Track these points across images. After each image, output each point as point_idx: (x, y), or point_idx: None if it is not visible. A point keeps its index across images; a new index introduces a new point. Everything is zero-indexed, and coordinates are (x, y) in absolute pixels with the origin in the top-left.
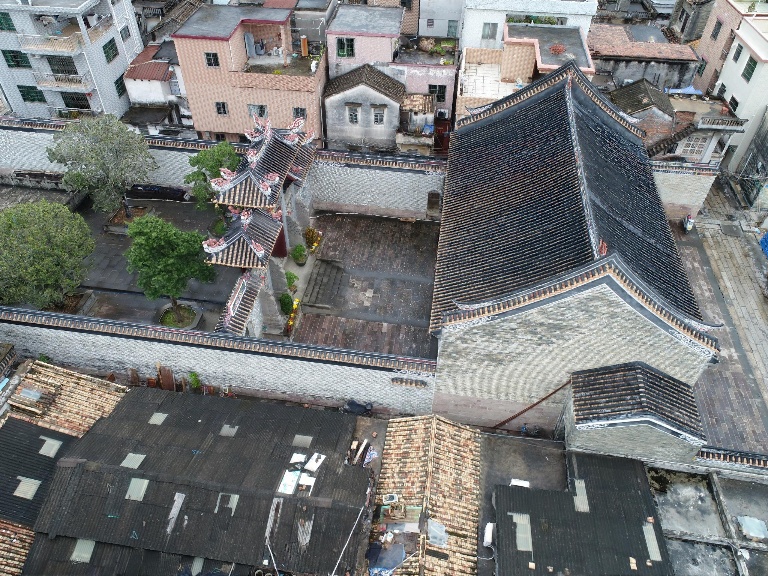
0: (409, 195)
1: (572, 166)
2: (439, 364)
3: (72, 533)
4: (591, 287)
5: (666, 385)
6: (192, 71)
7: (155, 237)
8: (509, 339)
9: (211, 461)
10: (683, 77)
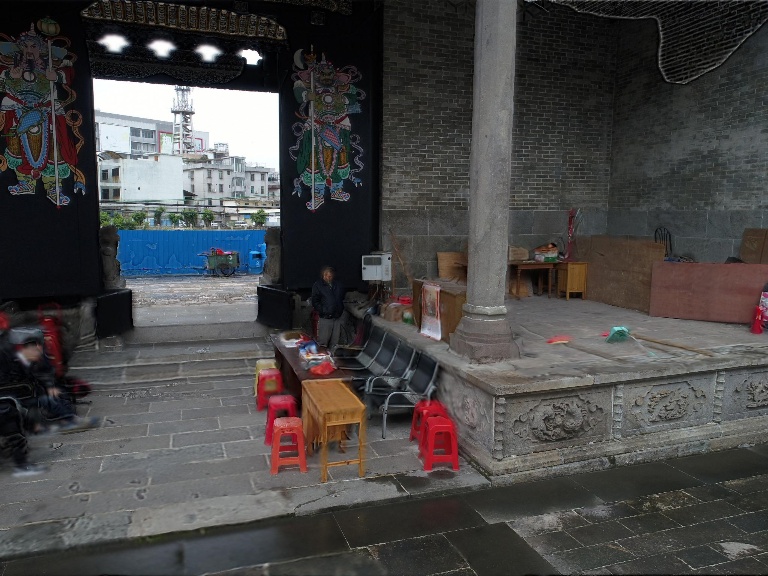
0: None
1: None
2: None
3: None
4: None
5: None
6: None
7: None
8: None
9: None
10: None
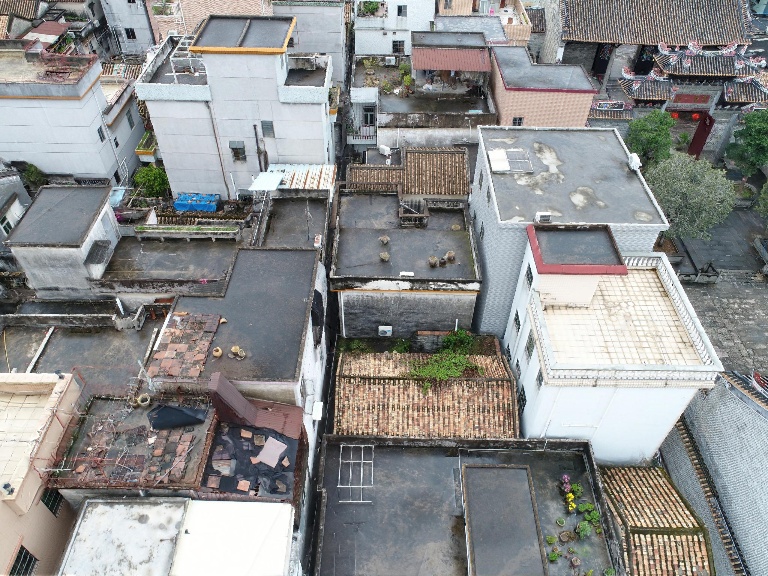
0: None
1: None
2: None
3: None
4: None
5: None
6: None
7: None
8: None
9: None
10: None
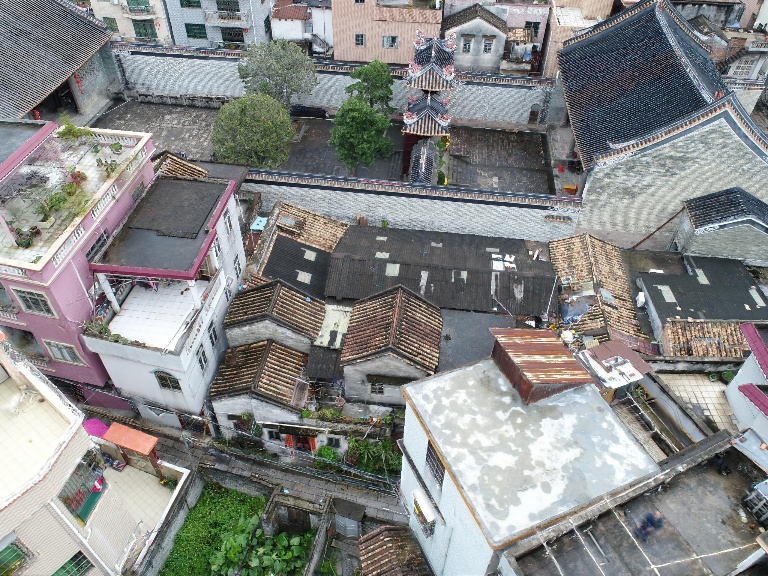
0: (515, 109)
1: (674, 59)
2: (585, 200)
3: (353, 296)
4: (712, 121)
5: (757, 204)
6: (341, 7)
7: (364, 112)
8: (643, 172)
9: (437, 256)
10: (728, 18)
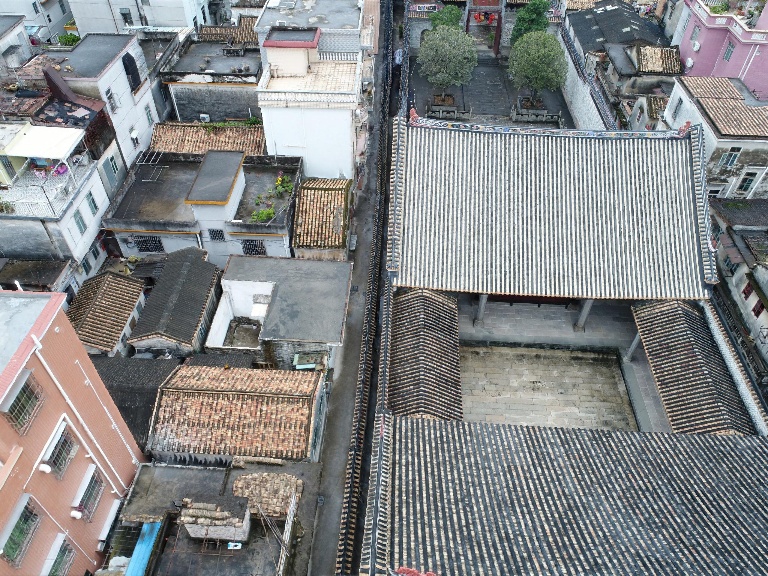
0: None
1: None
2: None
3: None
4: None
5: None
6: None
7: None
8: None
9: None
10: None
